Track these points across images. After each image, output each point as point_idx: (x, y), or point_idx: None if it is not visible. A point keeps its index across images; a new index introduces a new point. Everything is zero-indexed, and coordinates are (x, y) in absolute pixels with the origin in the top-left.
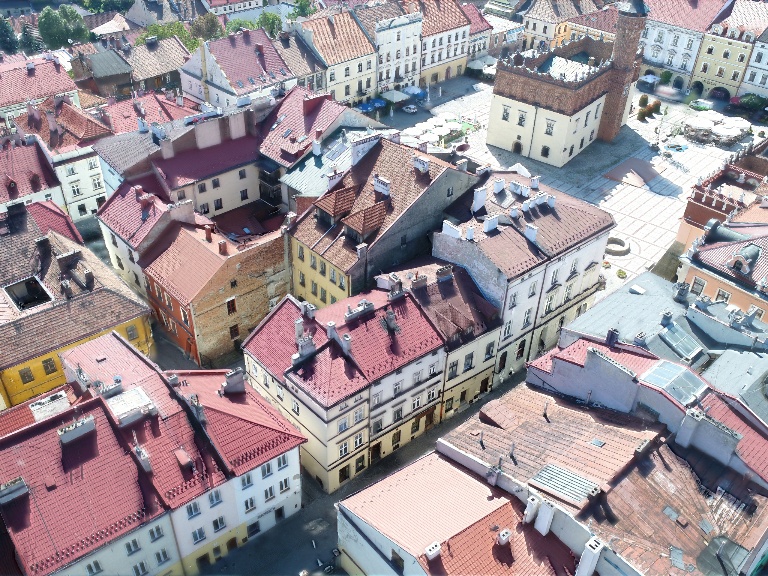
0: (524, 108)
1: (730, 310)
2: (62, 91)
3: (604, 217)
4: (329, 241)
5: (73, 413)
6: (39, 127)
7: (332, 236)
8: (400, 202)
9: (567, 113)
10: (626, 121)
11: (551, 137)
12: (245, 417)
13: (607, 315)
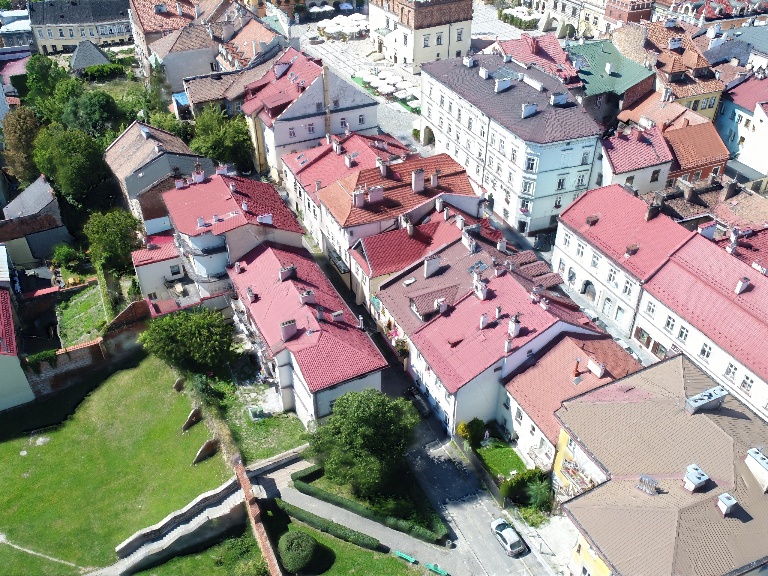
0: (440, 30)
1: None
2: (276, 193)
3: None
4: (696, 85)
5: None
6: (396, 203)
7: (693, 82)
8: (687, 46)
9: (470, 18)
10: None
11: (462, 42)
12: None
13: (763, 43)
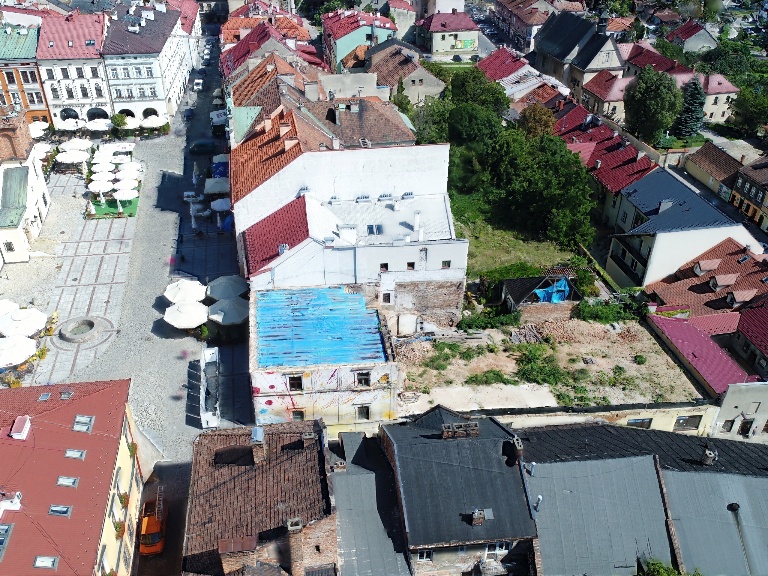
0: None
1: None
2: None
3: None
4: None
5: (3, 0)
6: None
7: None
8: None
9: None
10: None
11: None
12: None
13: None
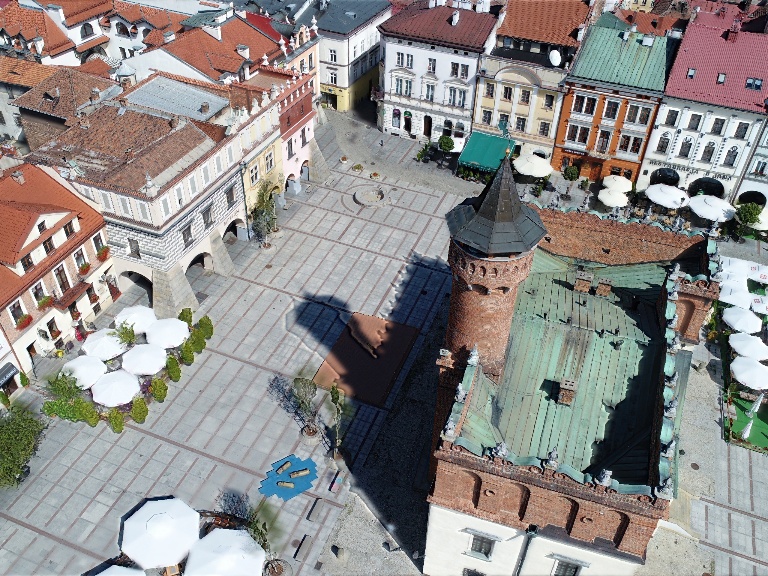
0: None
1: (293, 4)
2: None
3: (389, 23)
4: None
5: None
6: None
7: None
8: None
9: None
10: None
11: None
12: None
13: (368, 3)
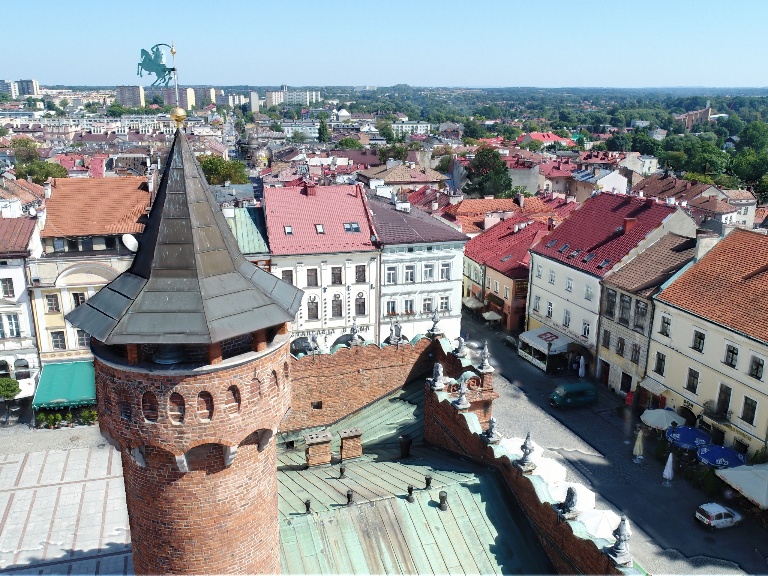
0: None
1: None
2: None
3: None
4: None
5: None
6: None
7: None
8: None
9: None
10: None
11: None
12: None
13: None
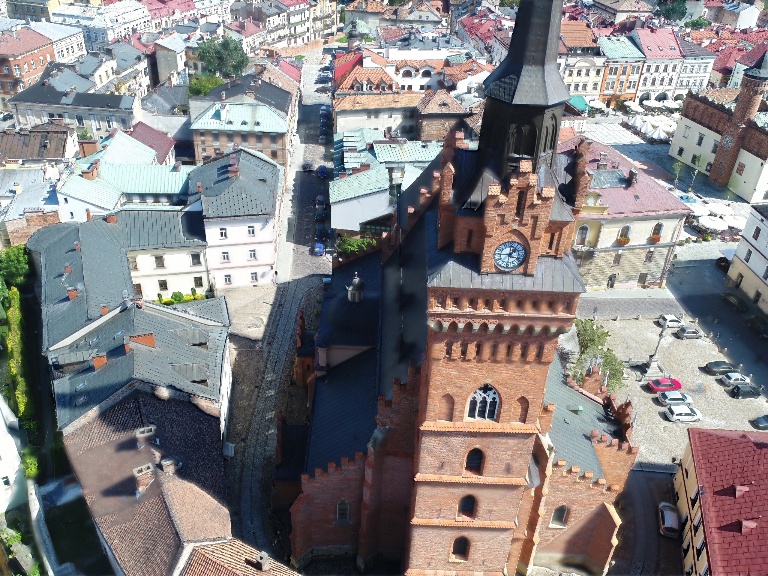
0: None
1: None
2: None
3: None
4: None
5: None
6: None
7: None
8: None
9: None
10: (751, 200)
11: None
12: (482, 29)
13: None
